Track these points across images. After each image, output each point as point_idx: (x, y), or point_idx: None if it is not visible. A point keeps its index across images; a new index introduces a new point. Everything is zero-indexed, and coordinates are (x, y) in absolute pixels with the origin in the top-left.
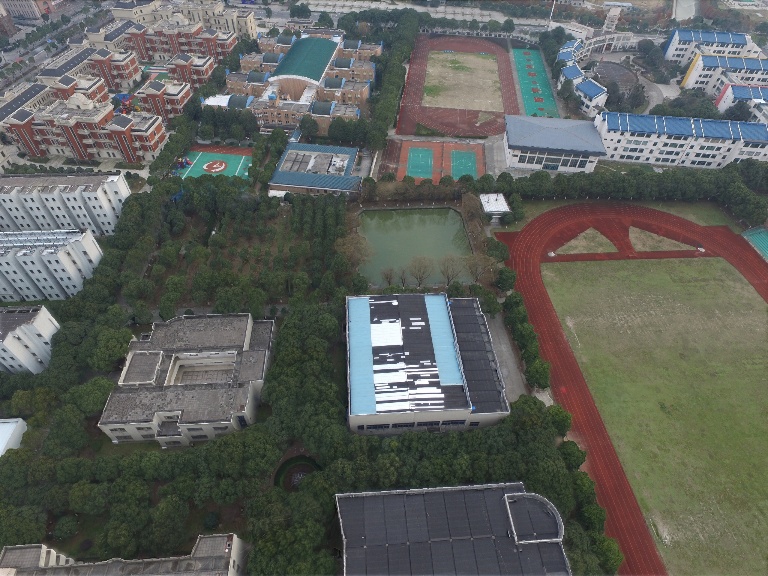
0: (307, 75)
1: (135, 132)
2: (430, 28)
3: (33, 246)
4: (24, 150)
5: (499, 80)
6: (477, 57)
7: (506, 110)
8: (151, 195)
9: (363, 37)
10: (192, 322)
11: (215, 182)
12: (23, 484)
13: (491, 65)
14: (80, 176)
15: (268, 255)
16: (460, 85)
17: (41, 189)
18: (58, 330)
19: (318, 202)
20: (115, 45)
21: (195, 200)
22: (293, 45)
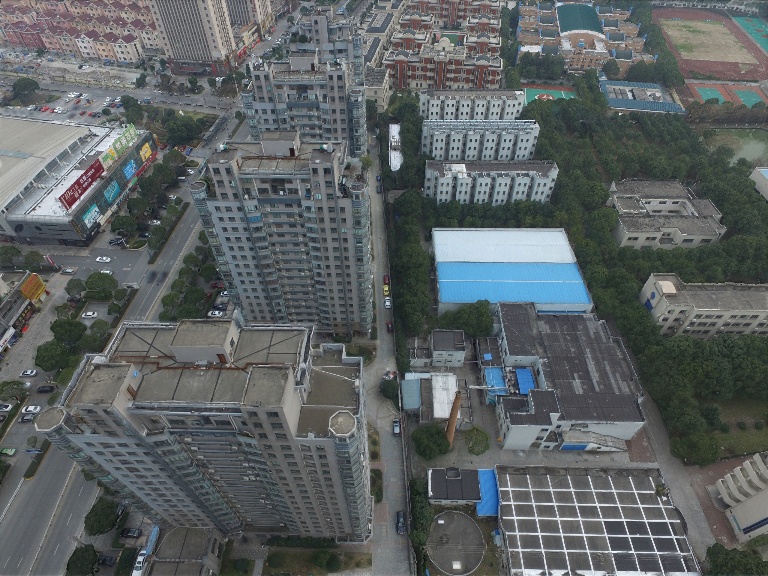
0: (595, 30)
1: (492, 68)
2: (650, 0)
3: (510, 129)
4: (392, 83)
5: (738, 40)
6: (705, 23)
7: (761, 62)
8: (538, 108)
9: (602, 6)
10: (638, 183)
11: (572, 103)
12: (602, 259)
13: (723, 29)
14: (493, 91)
15: (648, 150)
16: (706, 44)
17: (473, 98)
18: (557, 180)
19: (662, 118)
20: (398, 12)
21: (572, 113)
22: (558, 10)
